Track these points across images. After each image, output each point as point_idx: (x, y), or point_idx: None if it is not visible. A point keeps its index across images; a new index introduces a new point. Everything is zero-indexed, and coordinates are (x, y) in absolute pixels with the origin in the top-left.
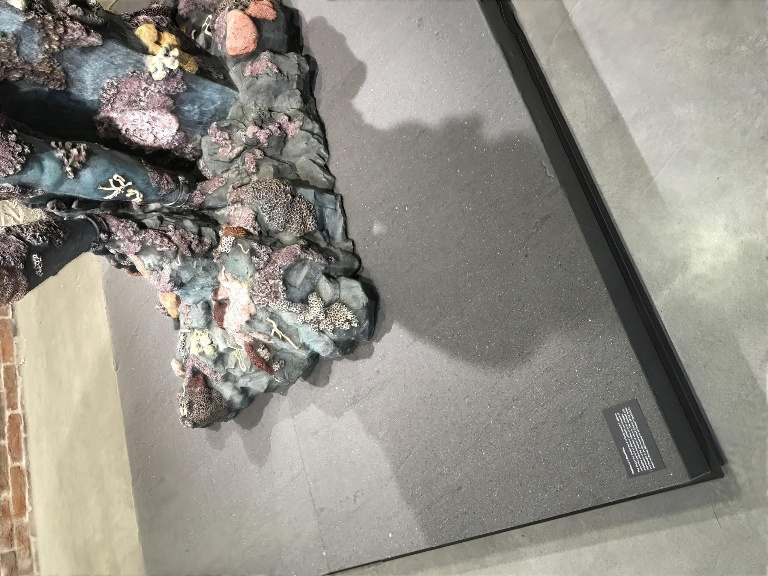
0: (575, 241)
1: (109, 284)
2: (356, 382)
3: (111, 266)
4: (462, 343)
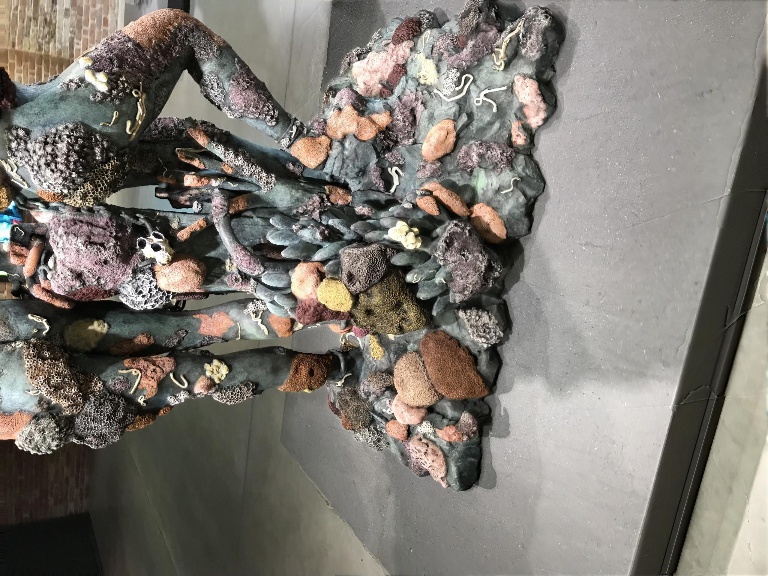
0: (330, 31)
1: (660, 355)
2: (419, 2)
3: (638, 375)
4: (371, 2)
